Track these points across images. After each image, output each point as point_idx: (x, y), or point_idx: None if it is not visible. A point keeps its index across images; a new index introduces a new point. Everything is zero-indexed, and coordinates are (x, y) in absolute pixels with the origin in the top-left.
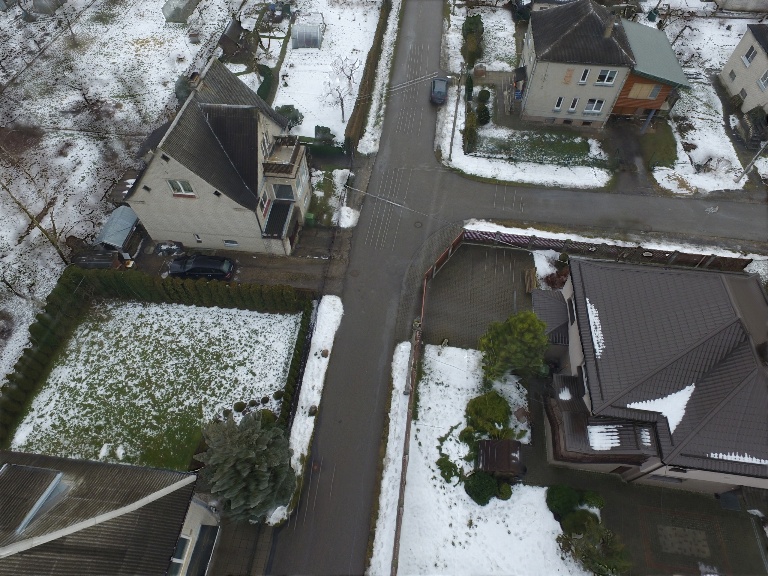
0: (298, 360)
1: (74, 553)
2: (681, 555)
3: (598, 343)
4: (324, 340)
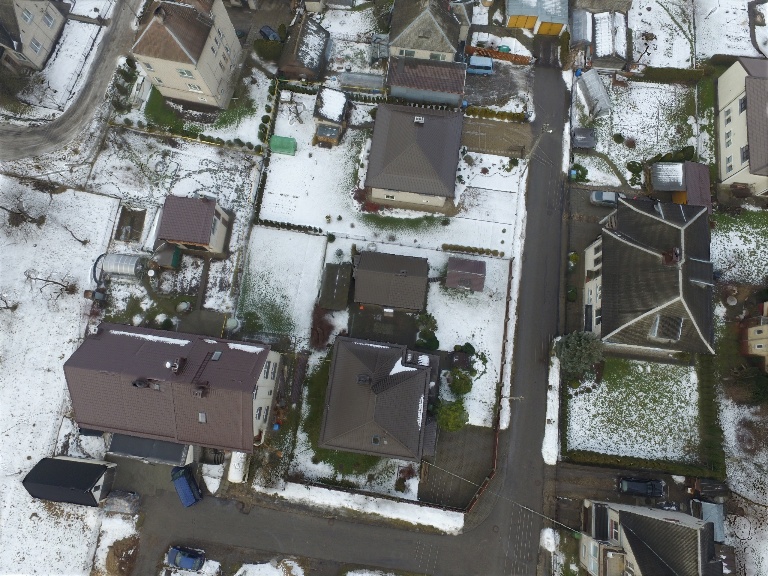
0: (564, 416)
1: (637, 310)
2: (387, 324)
3: (422, 402)
4: (551, 430)
